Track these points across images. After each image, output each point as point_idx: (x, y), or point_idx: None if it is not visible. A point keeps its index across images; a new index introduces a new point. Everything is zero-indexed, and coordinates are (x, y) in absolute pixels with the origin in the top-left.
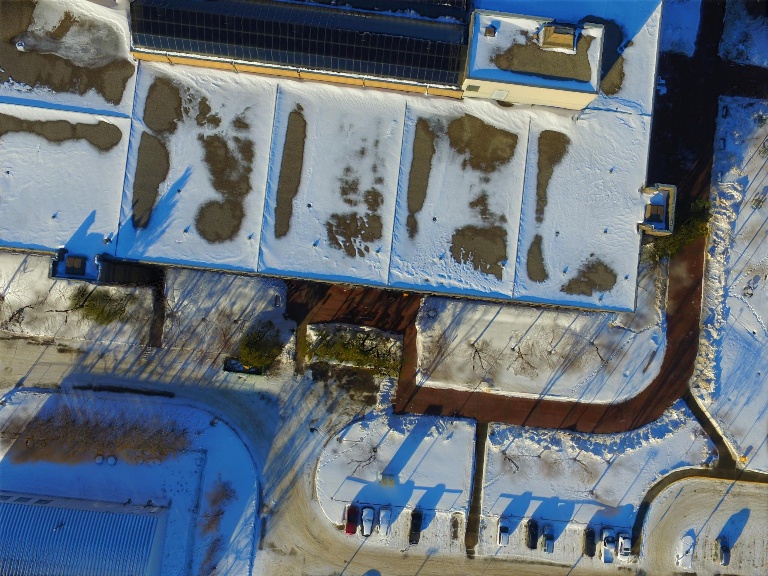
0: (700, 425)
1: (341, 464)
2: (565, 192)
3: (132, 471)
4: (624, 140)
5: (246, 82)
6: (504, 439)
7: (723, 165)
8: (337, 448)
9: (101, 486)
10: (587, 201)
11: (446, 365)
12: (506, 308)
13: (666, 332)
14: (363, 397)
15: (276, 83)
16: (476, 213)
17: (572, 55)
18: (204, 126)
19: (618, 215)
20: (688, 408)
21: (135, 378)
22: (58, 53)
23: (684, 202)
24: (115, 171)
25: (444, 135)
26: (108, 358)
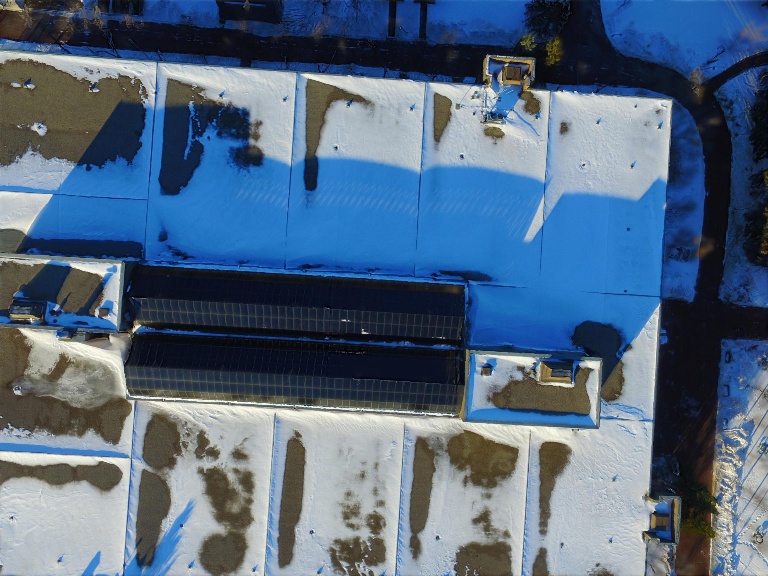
0: None
1: None
2: (568, 503)
3: None
4: (626, 447)
5: (243, 413)
6: None
7: (728, 411)
8: None
9: None
10: (591, 511)
11: None
12: None
13: None
14: None
15: (273, 413)
16: (479, 529)
17: (570, 388)
18: (203, 459)
19: (623, 524)
20: None
21: None
22: (55, 395)
23: (689, 451)
24: (117, 511)
25: (444, 453)
26: None
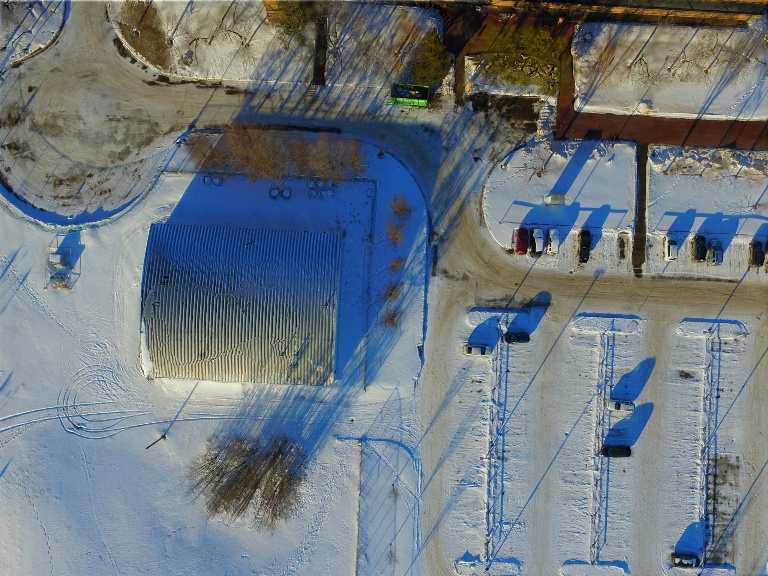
0: None
1: (507, 190)
2: None
3: (306, 204)
4: None
5: None
6: (665, 159)
7: None
8: (502, 175)
9: (277, 220)
10: None
11: (604, 89)
12: (661, 28)
13: None
14: (523, 125)
15: None
16: None
17: None
18: None
19: None
20: None
21: (302, 116)
22: None
23: None
24: None
25: None
26: (274, 98)
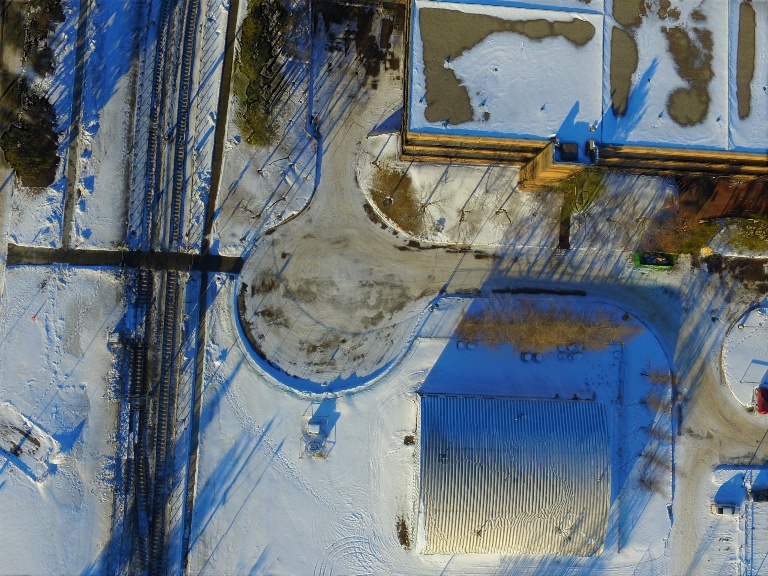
0: None
1: (745, 349)
2: None
3: (556, 367)
4: None
5: None
6: None
7: None
8: (739, 334)
9: (529, 383)
10: None
11: None
12: None
13: None
14: (756, 285)
15: None
16: None
17: None
18: (666, 19)
19: None
20: None
21: (548, 279)
22: None
23: None
24: (593, 64)
25: None
26: (522, 262)
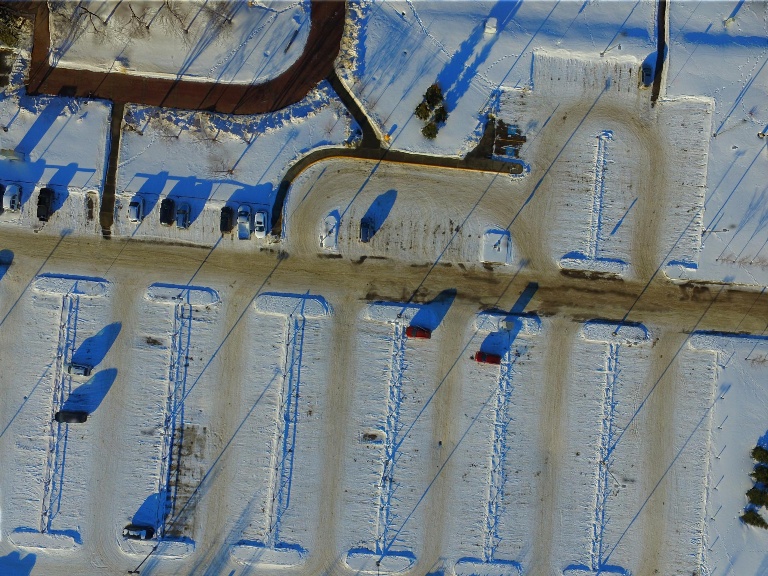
0: (344, 105)
1: None
2: None
3: None
4: None
5: None
6: (139, 119)
7: None
8: None
9: None
10: None
11: (79, 45)
12: None
13: (310, 13)
14: None
15: None
16: None
17: None
18: None
19: None
20: (332, 89)
21: None
22: None
23: None
24: None
25: None
26: None
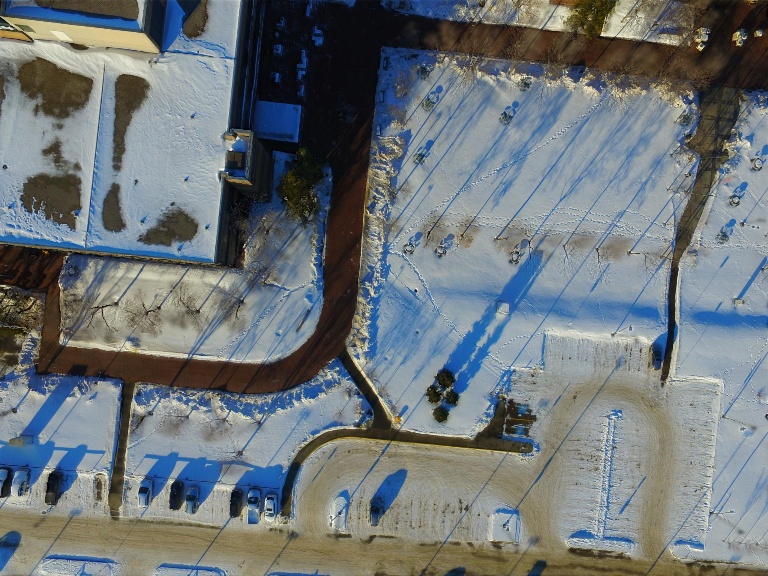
0: (355, 385)
1: None
2: (144, 139)
3: None
4: (206, 84)
5: None
6: (150, 399)
7: (384, 118)
8: None
9: None
10: (167, 148)
11: None
12: (150, 265)
13: (323, 290)
14: (4, 357)
15: None
16: (49, 161)
17: None
18: None
19: (200, 162)
20: (344, 368)
21: None
22: None
23: (343, 157)
24: None
25: (15, 79)
26: None
